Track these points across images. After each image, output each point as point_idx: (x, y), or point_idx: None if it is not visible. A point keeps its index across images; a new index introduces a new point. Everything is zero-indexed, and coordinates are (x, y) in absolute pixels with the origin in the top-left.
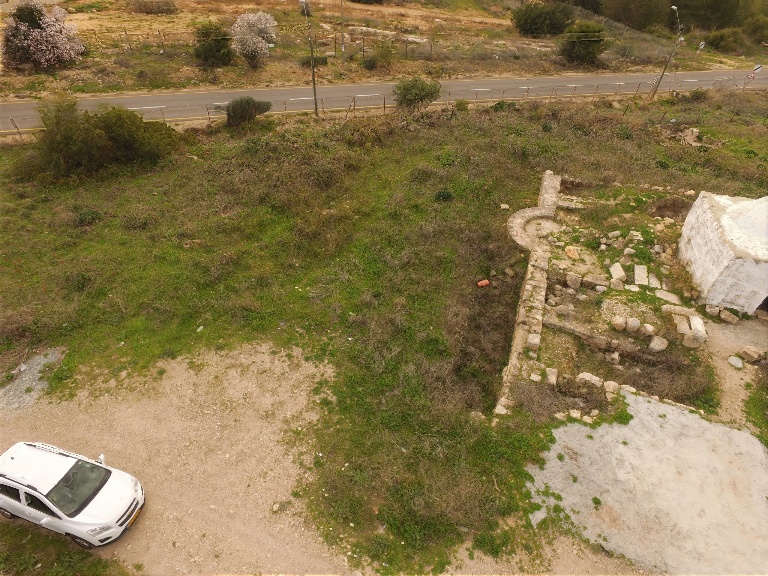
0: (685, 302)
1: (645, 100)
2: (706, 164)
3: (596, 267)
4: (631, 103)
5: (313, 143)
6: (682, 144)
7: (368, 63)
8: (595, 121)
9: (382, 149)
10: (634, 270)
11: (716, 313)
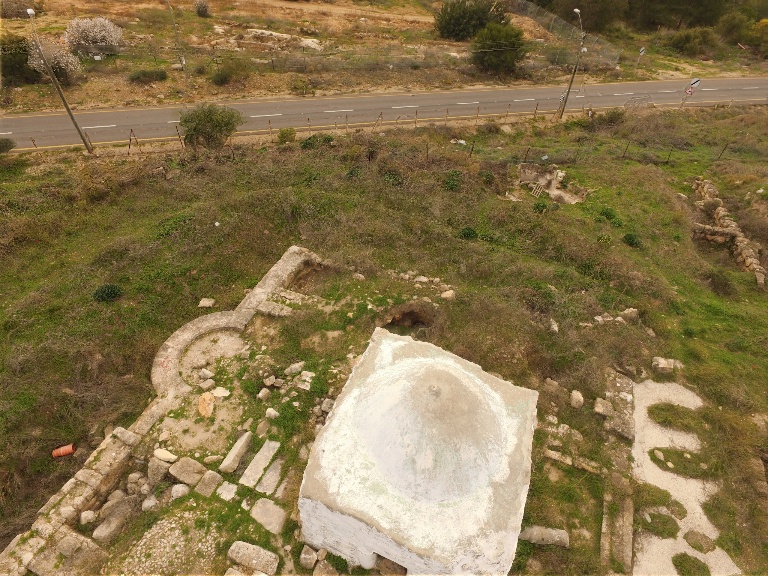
0: (285, 530)
1: (549, 122)
2: (530, 233)
3: (219, 436)
4: (527, 126)
5: (8, 201)
6: (533, 195)
7: (219, 77)
8: (426, 163)
9: (109, 207)
10: (258, 451)
11: (310, 564)
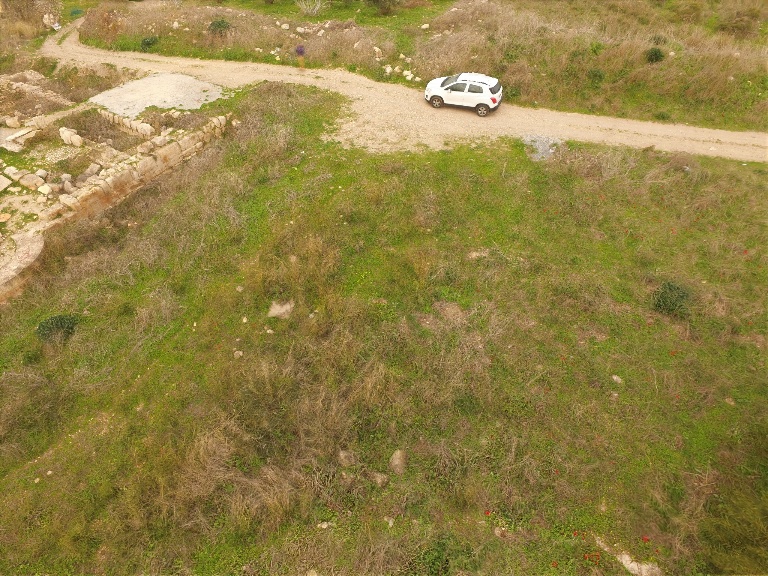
0: None
1: None
2: None
3: (4, 201)
4: None
5: None
6: None
7: None
8: None
9: None
10: None
11: None
